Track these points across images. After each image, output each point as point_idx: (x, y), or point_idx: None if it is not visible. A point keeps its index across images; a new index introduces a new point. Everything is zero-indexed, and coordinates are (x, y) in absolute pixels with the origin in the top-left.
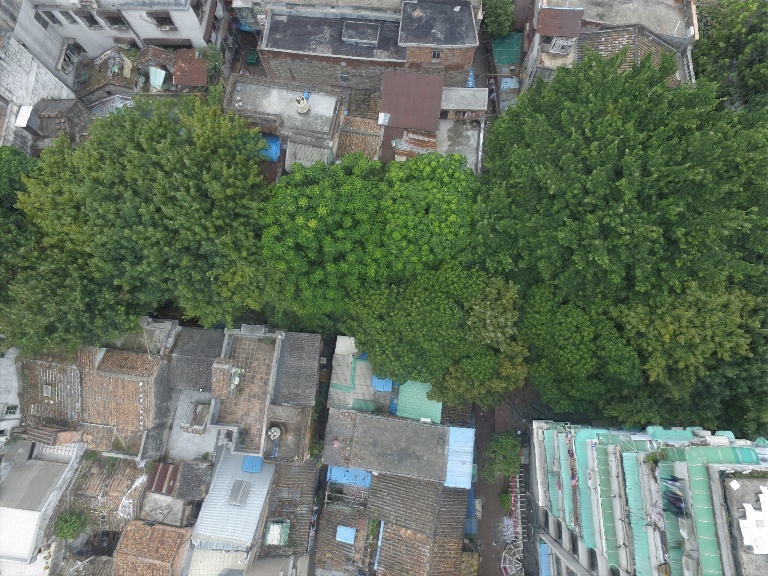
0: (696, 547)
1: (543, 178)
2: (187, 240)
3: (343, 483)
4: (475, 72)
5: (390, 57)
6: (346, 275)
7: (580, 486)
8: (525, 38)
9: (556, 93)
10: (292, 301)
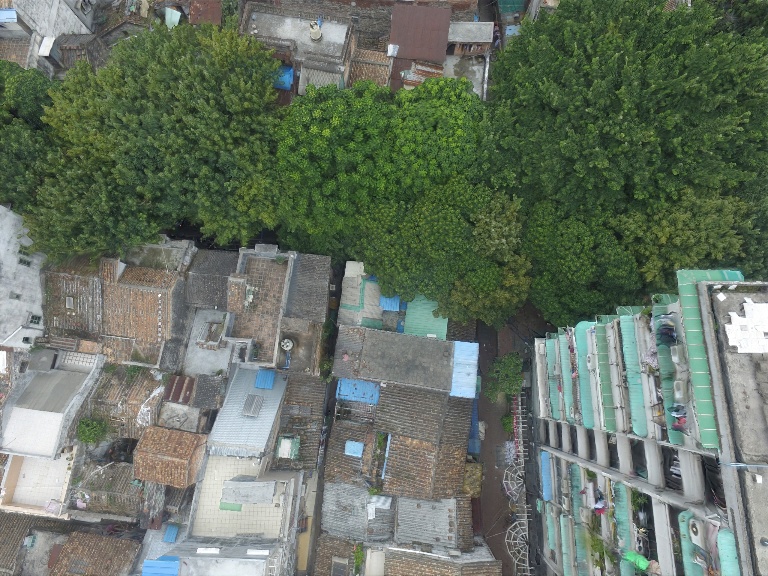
0: (686, 368)
1: (546, 92)
2: (206, 151)
3: None
4: None
5: None
6: (357, 189)
7: (580, 373)
8: None
9: (559, 17)
10: (305, 218)
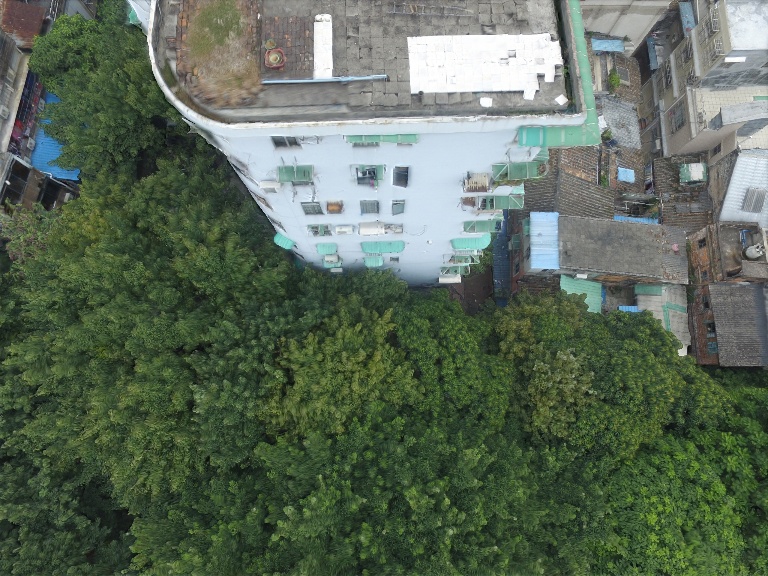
0: None
1: None
2: None
3: None
4: None
5: None
6: None
7: None
8: None
9: None
10: None
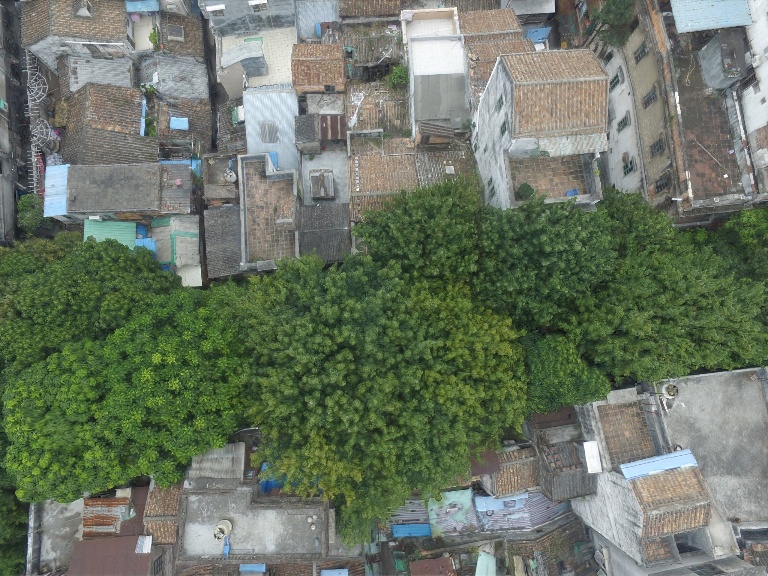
0: None
1: None
2: None
3: None
4: None
5: None
6: None
7: None
8: None
9: None
10: None
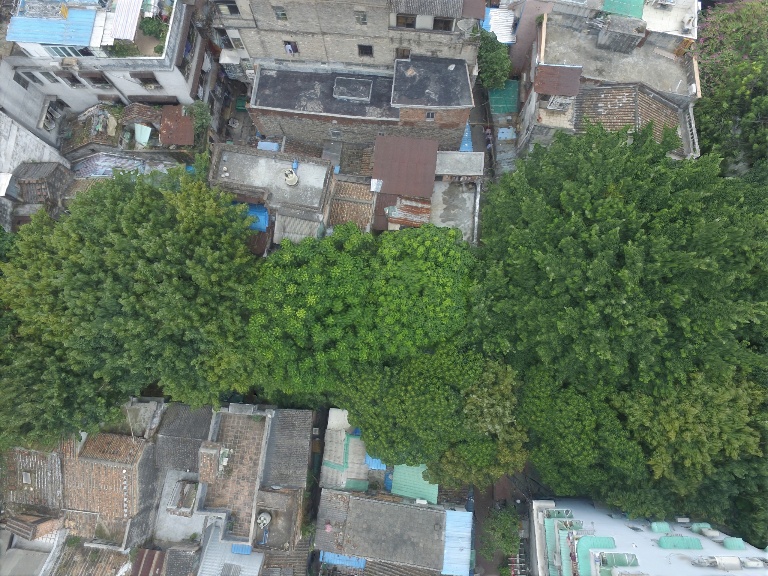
0: None
1: (542, 263)
2: (170, 329)
3: (337, 562)
4: (471, 118)
5: (383, 114)
6: (337, 360)
7: None
8: (522, 88)
9: (555, 167)
10: (281, 383)
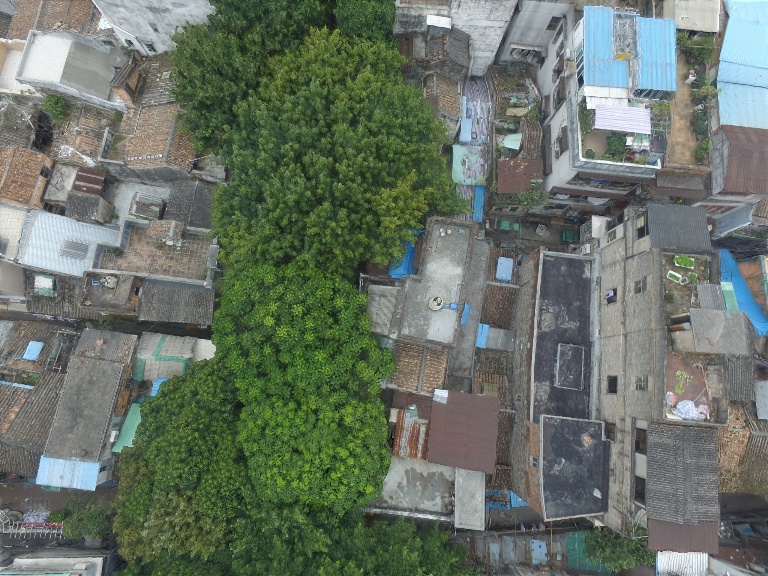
0: None
1: None
2: None
3: None
4: None
5: (540, 402)
6: None
7: None
8: None
9: None
10: None
